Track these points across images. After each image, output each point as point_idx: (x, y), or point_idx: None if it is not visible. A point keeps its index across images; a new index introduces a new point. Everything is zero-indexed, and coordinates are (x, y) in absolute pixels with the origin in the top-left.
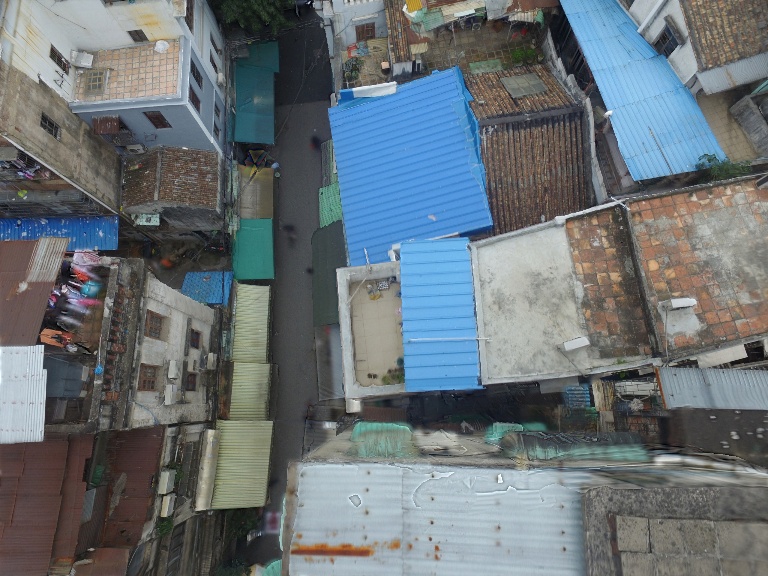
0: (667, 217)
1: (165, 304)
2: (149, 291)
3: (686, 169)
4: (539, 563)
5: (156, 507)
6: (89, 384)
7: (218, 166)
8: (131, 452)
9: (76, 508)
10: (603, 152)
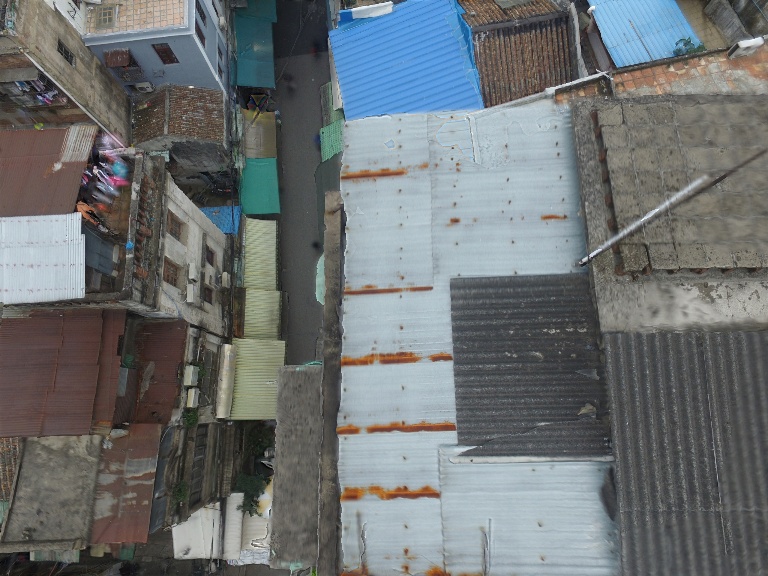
0: (647, 86)
1: (183, 210)
2: (169, 191)
3: (664, 55)
4: (539, 166)
5: (182, 398)
6: (120, 265)
7: (223, 105)
8: (158, 343)
9: (112, 378)
10: (588, 56)
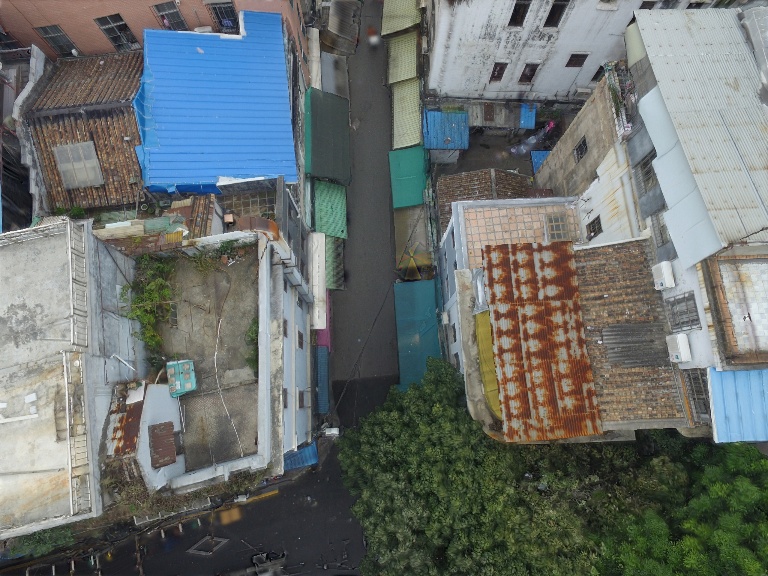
0: None
1: None
2: None
3: None
4: None
5: None
6: None
7: None
8: None
9: None
10: None
